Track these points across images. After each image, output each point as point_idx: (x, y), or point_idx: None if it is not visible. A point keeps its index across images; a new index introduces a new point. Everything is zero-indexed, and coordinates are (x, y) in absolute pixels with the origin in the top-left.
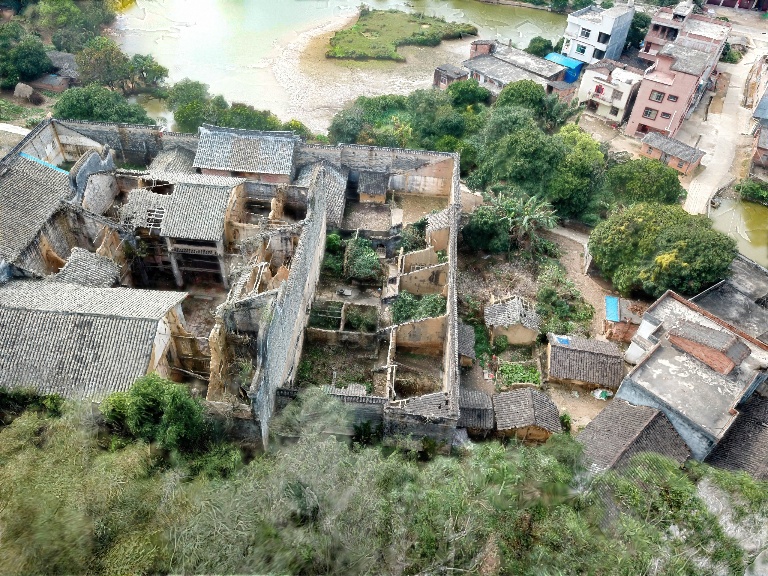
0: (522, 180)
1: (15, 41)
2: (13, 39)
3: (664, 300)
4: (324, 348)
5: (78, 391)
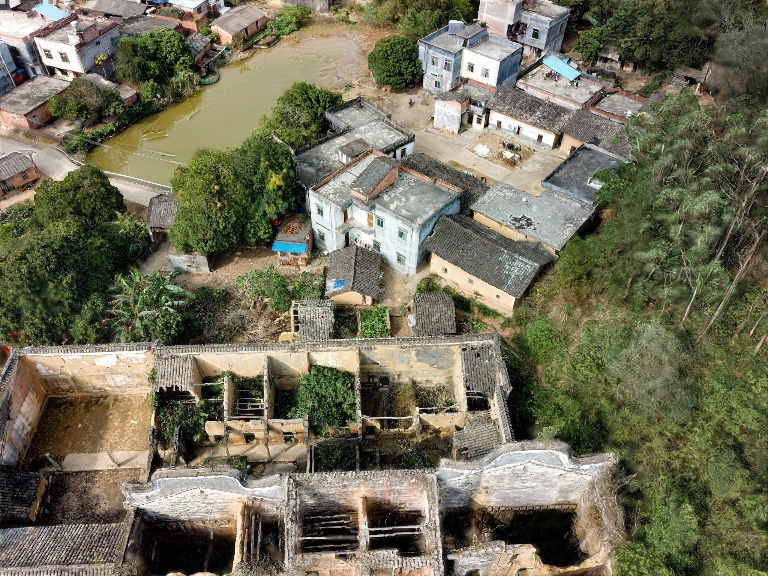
0: None
1: None
2: None
3: None
4: None
5: None
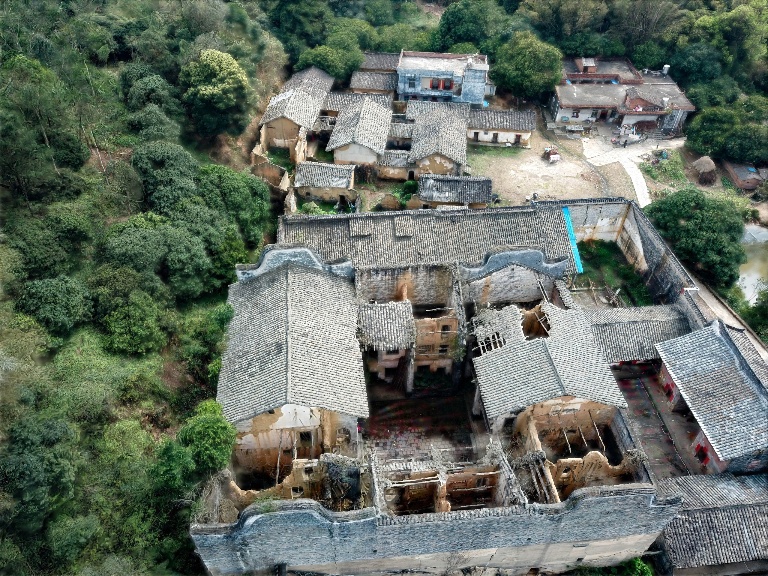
0: None
1: (766, 120)
2: (766, 118)
3: None
4: None
5: None
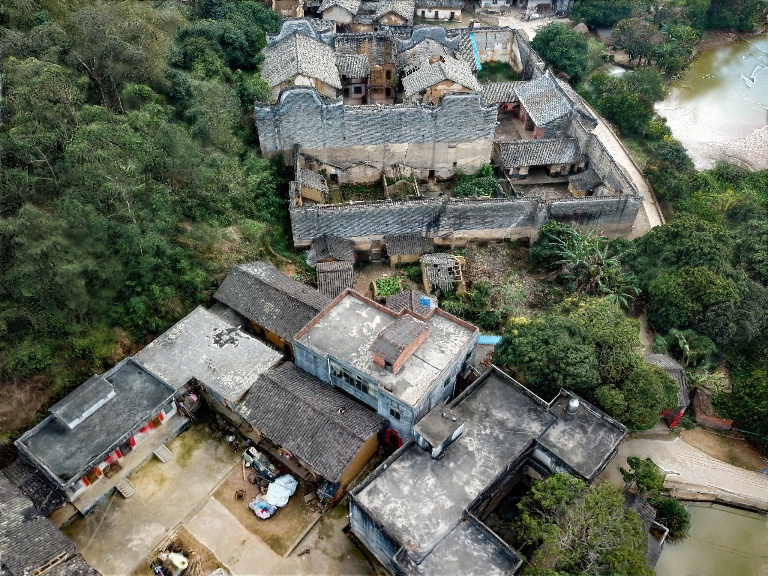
0: (648, 254)
1: None
2: None
3: (466, 329)
4: (380, 193)
5: (170, 2)
